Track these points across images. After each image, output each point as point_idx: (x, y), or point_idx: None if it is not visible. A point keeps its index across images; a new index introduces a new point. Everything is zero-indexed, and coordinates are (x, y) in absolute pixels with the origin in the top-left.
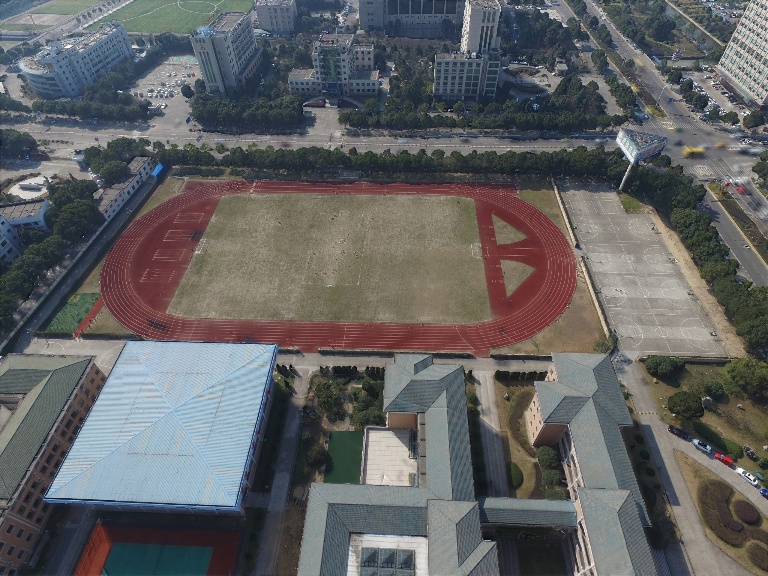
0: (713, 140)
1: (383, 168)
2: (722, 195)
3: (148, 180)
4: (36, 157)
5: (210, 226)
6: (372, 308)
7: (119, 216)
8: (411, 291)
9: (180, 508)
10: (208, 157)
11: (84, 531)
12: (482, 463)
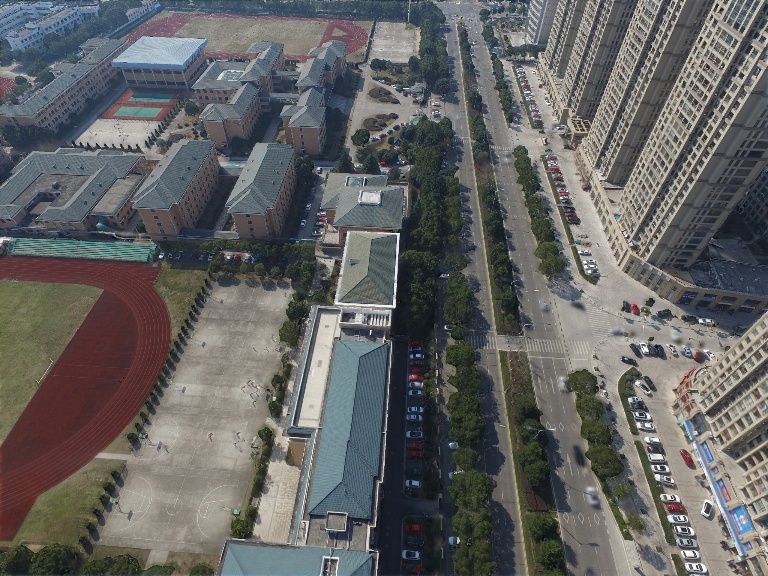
0: (477, 8)
1: (283, 8)
2: (460, 25)
3: (152, 12)
4: (87, 1)
5: (184, 26)
6: None
7: (136, 22)
8: None
9: (162, 85)
10: (186, 0)
11: None
12: None
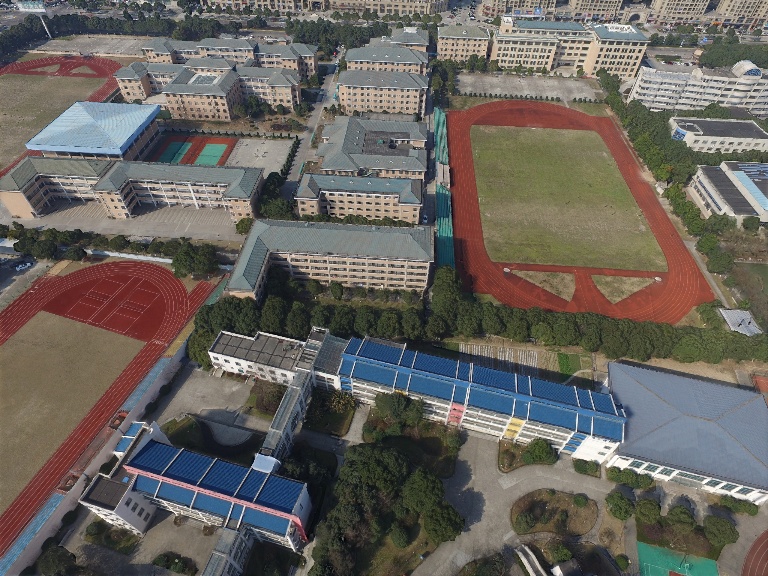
0: None
1: None
2: None
3: None
4: None
5: None
6: (67, 106)
7: None
8: (65, 96)
9: None
10: None
11: None
12: None
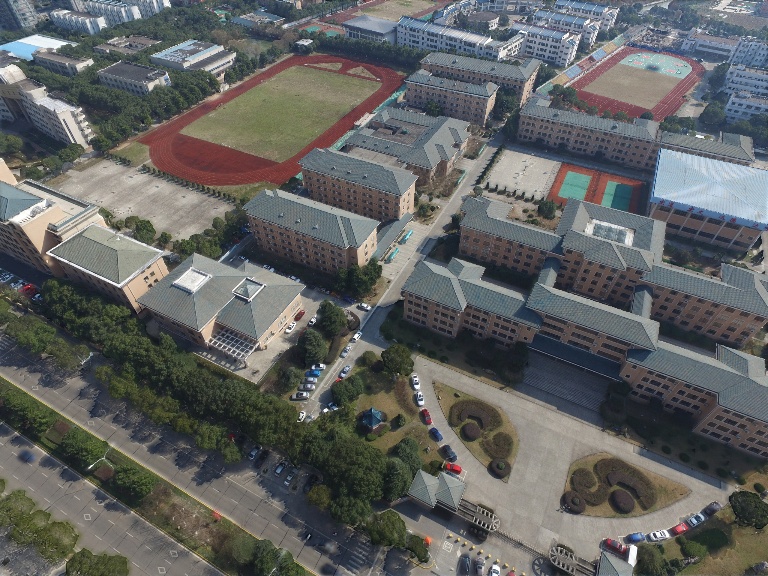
0: None
1: None
2: None
3: None
4: None
5: None
6: None
7: None
8: None
9: None
10: None
11: (640, 179)
12: (677, 331)
